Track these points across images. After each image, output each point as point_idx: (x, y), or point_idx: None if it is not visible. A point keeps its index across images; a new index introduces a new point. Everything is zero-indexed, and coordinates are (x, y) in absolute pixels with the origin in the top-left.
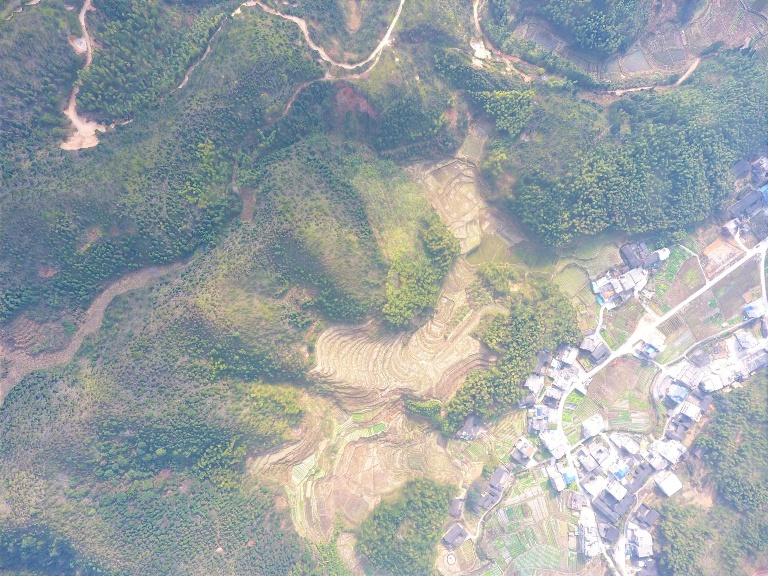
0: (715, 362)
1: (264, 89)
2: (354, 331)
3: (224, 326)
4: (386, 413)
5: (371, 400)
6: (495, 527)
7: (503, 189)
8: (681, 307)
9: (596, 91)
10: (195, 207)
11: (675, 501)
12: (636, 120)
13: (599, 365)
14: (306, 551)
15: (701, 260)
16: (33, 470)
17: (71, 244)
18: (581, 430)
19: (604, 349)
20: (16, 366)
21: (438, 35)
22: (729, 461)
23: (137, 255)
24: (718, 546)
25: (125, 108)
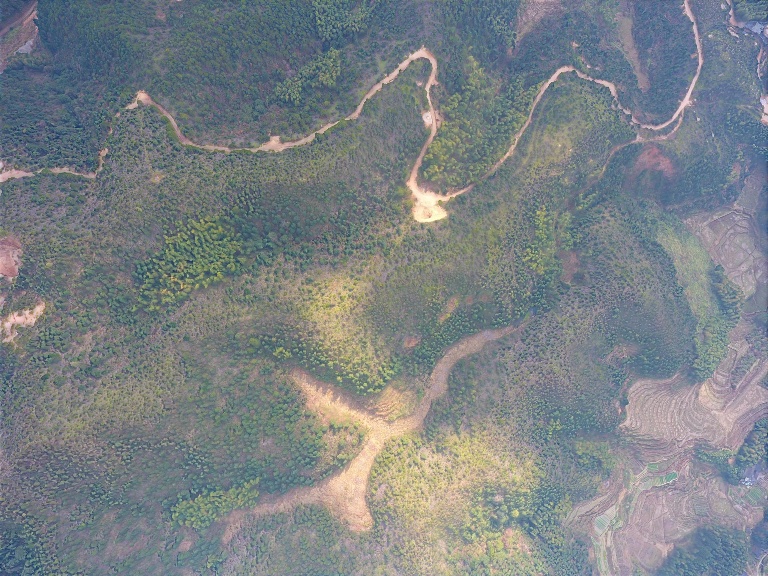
0: None
1: (592, 155)
2: (659, 385)
3: (575, 390)
4: (678, 462)
5: (669, 451)
6: None
7: None
8: None
9: None
10: (533, 273)
11: None
12: None
13: None
14: None
15: None
16: (423, 538)
17: (437, 315)
18: None
19: None
20: (374, 433)
21: (735, 94)
22: None
23: (482, 321)
24: None
25: (464, 178)
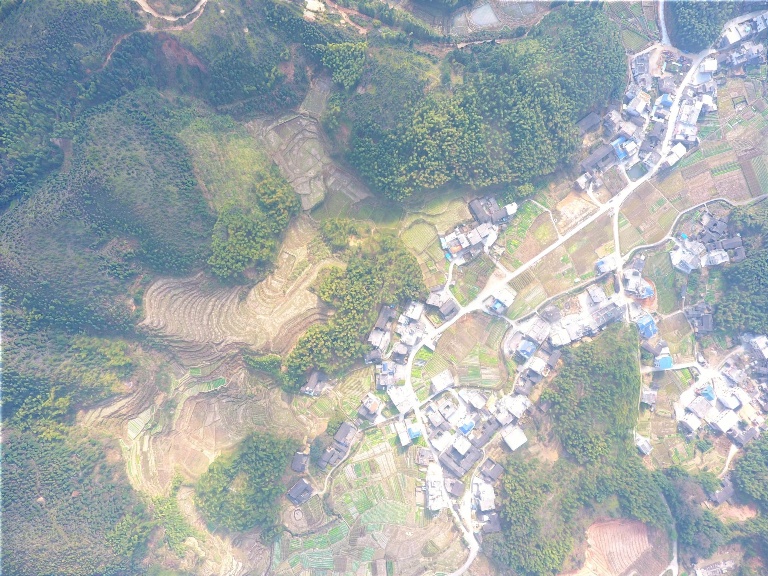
0: (567, 317)
1: (76, 39)
2: (184, 284)
3: (29, 274)
4: (225, 368)
5: (206, 354)
6: (343, 483)
7: (340, 143)
8: (533, 263)
9: (436, 44)
10: (6, 157)
11: (520, 455)
12: (467, 70)
13: (448, 321)
14: (139, 504)
15: (554, 215)
16: None
17: None
18: (430, 386)
19: (451, 304)
20: None
21: None
22: (569, 414)
23: None
24: (555, 498)
25: None
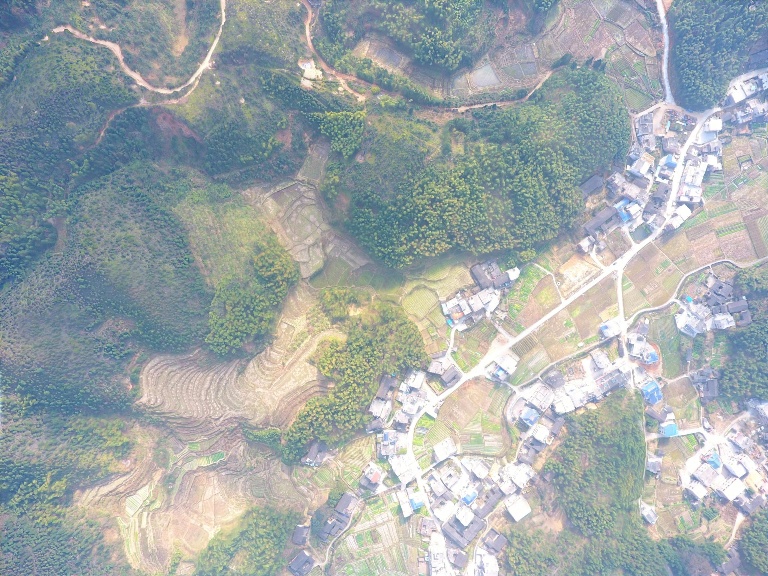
0: (570, 383)
1: (69, 118)
2: (181, 361)
3: (23, 363)
4: (224, 442)
5: (205, 429)
6: (344, 553)
7: (339, 212)
8: (535, 327)
9: (436, 109)
10: None
11: (523, 526)
12: (468, 140)
13: (450, 388)
14: None
15: (556, 279)
16: None
17: None
18: (432, 454)
19: (453, 372)
20: None
21: (261, 56)
22: (574, 486)
23: None
24: (560, 572)
25: None
